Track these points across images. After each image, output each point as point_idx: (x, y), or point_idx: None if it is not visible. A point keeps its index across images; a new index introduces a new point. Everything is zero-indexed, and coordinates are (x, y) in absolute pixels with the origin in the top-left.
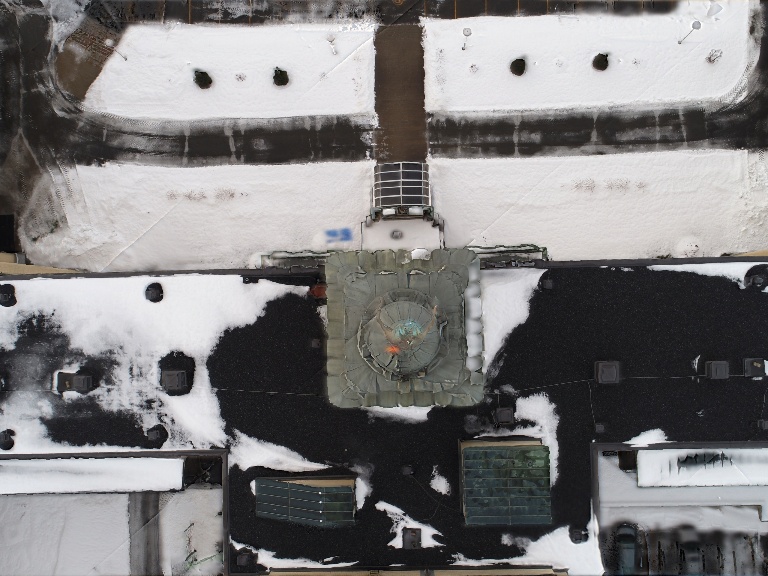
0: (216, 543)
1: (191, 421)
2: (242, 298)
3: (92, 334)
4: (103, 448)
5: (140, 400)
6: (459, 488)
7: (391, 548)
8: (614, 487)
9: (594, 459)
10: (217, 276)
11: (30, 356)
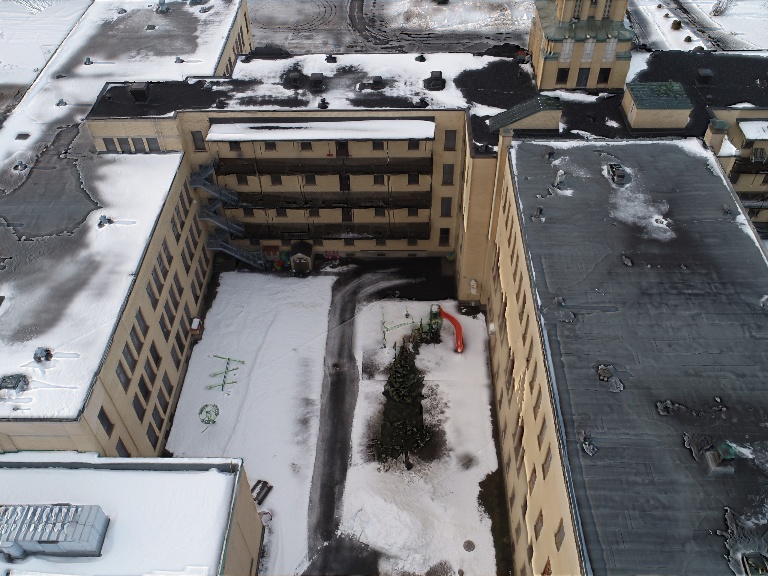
0: (403, 336)
1: (445, 98)
2: (474, 60)
3: (382, 72)
4: (387, 108)
5: (411, 93)
6: (626, 124)
7: None
8: None
9: (711, 112)
10: (458, 53)
11: (343, 79)
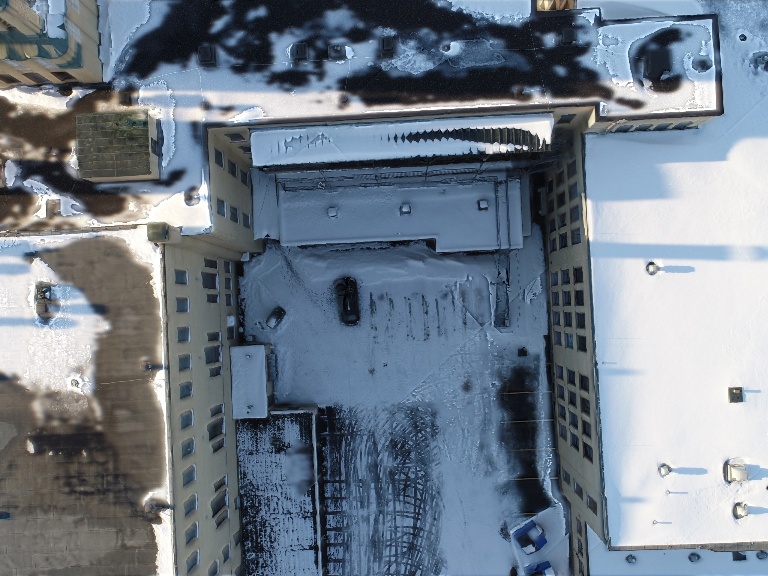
0: None
1: None
2: None
3: None
4: None
5: None
6: None
7: (37, 218)
8: (308, 228)
9: (204, 134)
10: None
11: None
